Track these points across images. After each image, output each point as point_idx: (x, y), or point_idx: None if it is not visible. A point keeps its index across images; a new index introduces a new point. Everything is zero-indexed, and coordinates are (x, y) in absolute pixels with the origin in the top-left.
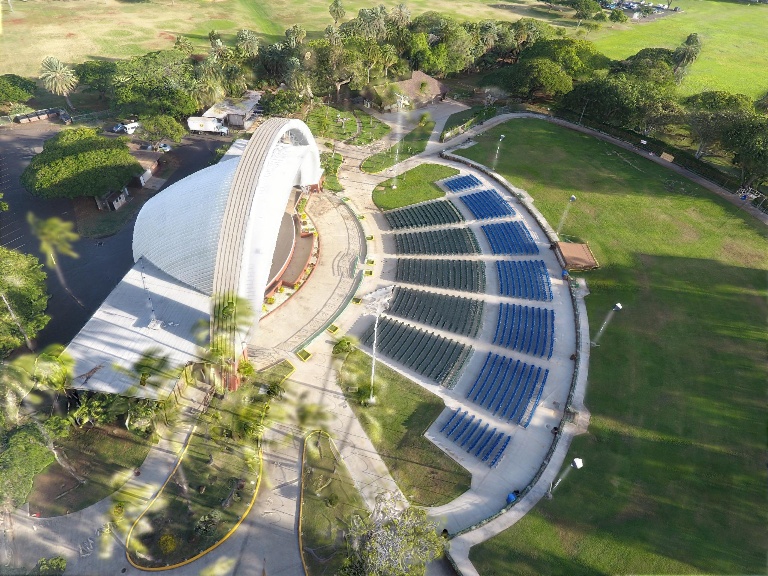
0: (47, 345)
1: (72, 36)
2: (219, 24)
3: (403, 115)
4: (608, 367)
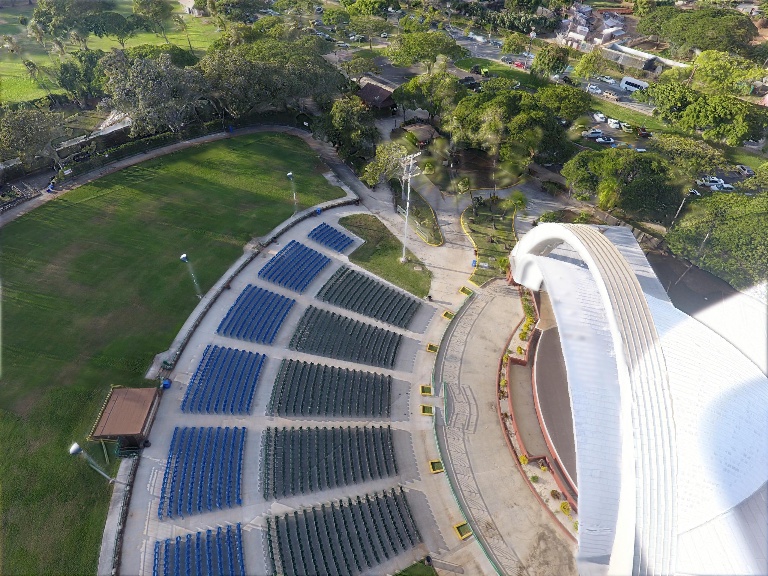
0: (681, 288)
1: None
2: None
3: None
4: (204, 277)
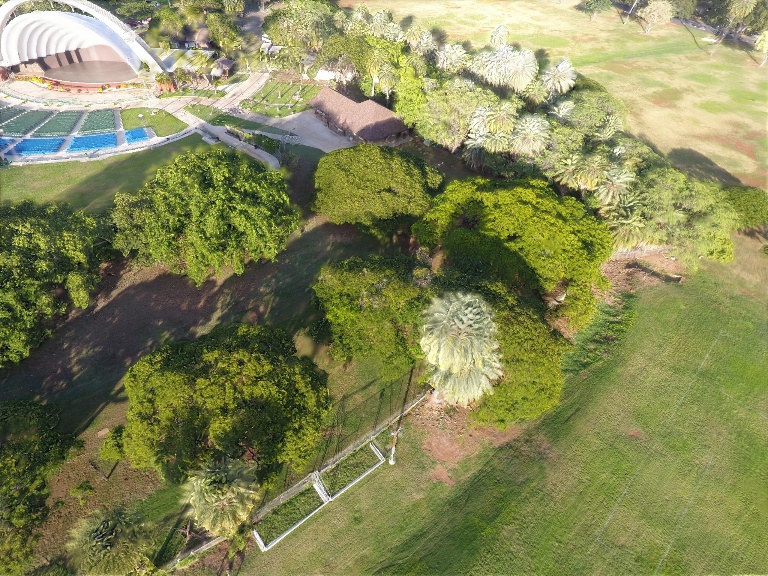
0: None
1: (454, 8)
2: (551, 41)
3: (313, 123)
4: None
